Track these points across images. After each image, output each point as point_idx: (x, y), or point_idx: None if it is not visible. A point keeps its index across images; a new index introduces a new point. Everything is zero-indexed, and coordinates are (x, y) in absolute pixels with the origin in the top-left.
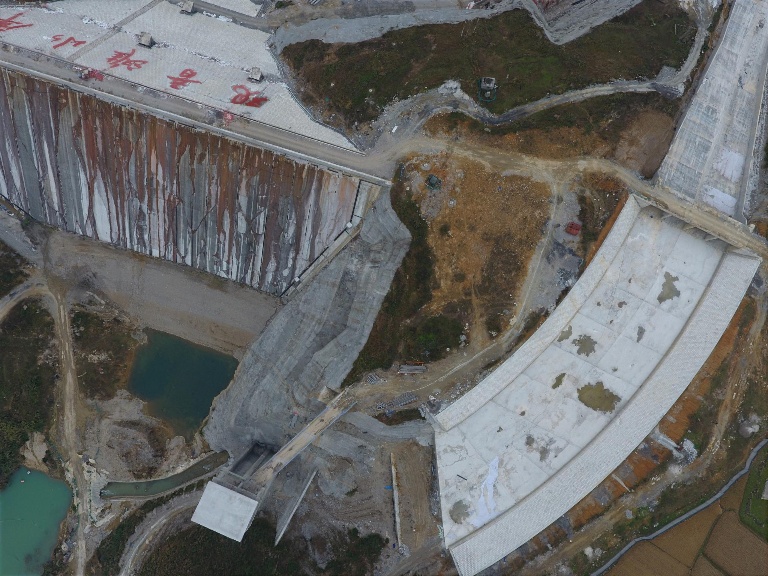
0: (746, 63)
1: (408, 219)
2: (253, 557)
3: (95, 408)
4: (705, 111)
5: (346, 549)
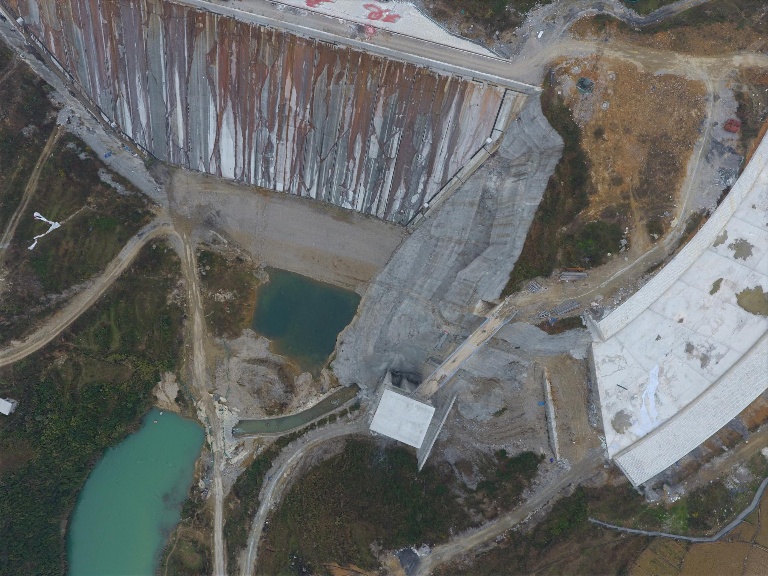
0: None
1: (561, 124)
2: (401, 482)
3: (223, 347)
4: None
5: (495, 470)
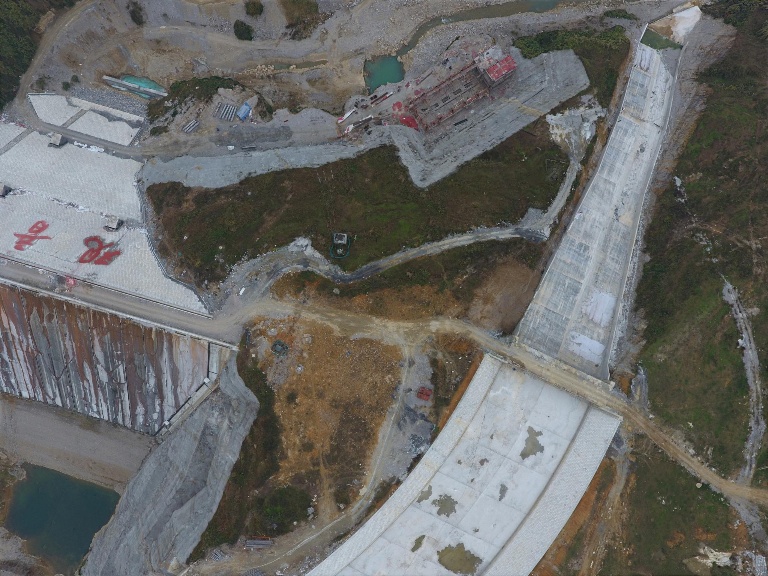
0: (624, 193)
1: (254, 387)
2: None
3: None
4: (577, 249)
5: None
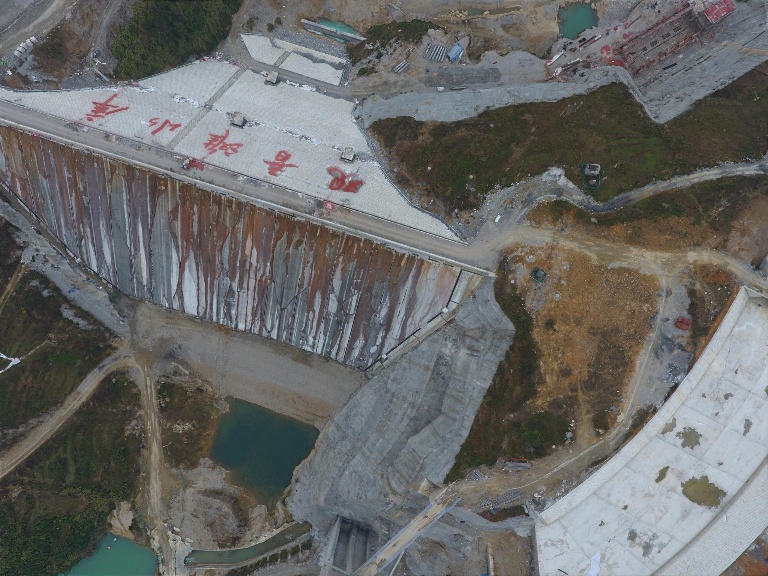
0: None
1: (513, 313)
2: None
3: (180, 477)
4: None
5: None
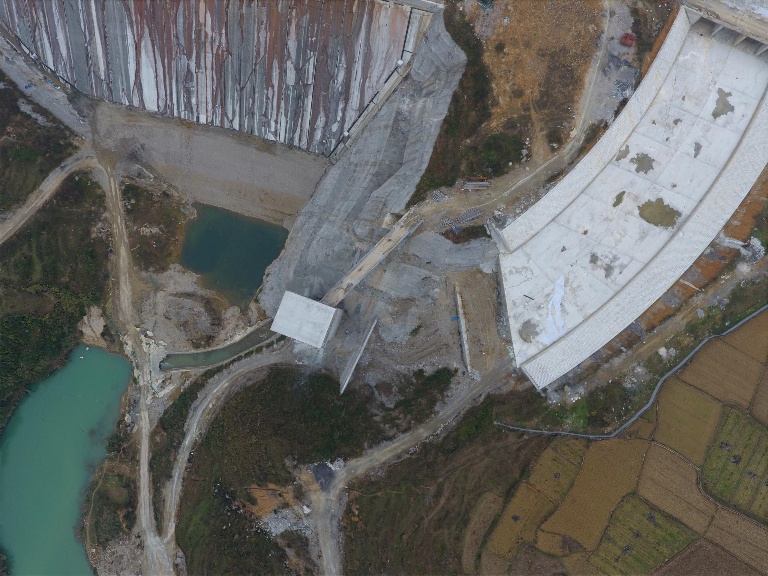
0: None
1: (463, 39)
2: (321, 403)
3: (150, 281)
4: None
5: (413, 389)
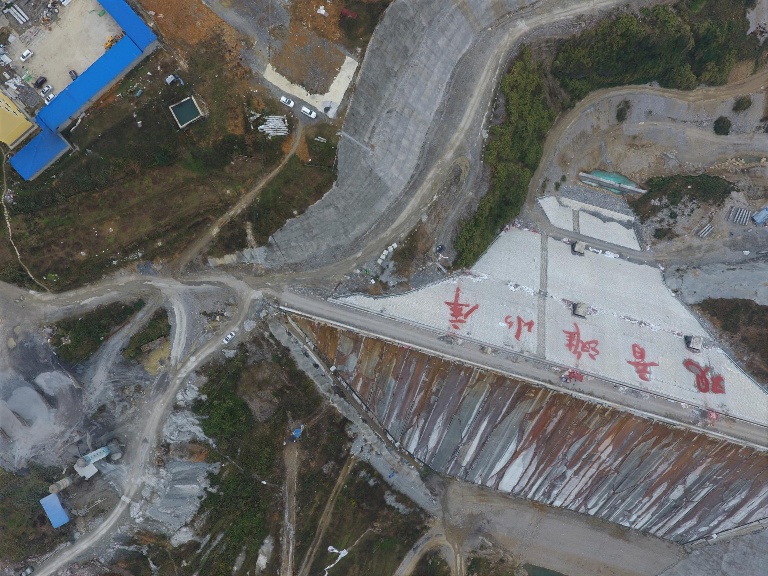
0: None
1: None
2: None
3: None
4: None
5: None
